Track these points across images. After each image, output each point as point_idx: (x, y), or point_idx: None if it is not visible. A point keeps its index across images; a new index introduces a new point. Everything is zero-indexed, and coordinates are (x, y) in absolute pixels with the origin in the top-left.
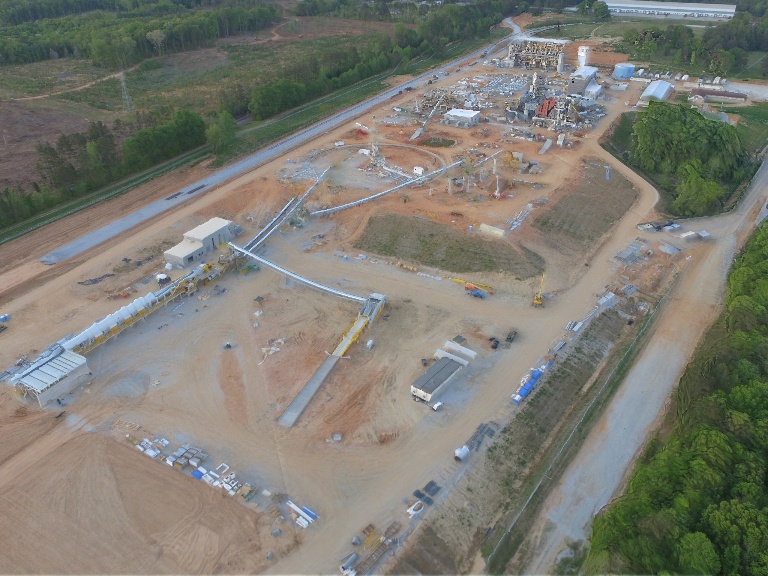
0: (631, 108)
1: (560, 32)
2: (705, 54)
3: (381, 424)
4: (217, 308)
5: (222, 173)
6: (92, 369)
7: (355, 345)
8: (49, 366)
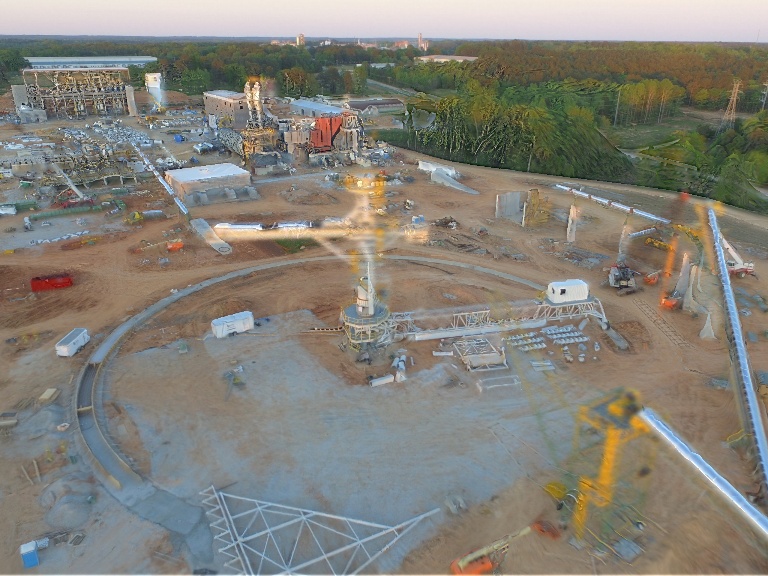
0: None
1: (9, 83)
2: None
3: None
4: None
5: None
6: None
7: None
8: None
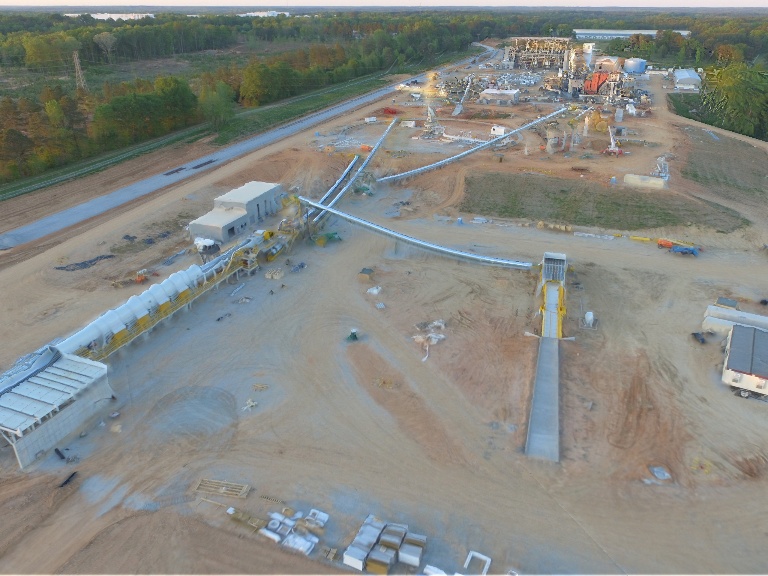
0: (673, 90)
1: None
2: (705, 53)
3: (719, 441)
4: (303, 288)
5: (231, 149)
6: (114, 390)
7: (566, 321)
8: (32, 384)
